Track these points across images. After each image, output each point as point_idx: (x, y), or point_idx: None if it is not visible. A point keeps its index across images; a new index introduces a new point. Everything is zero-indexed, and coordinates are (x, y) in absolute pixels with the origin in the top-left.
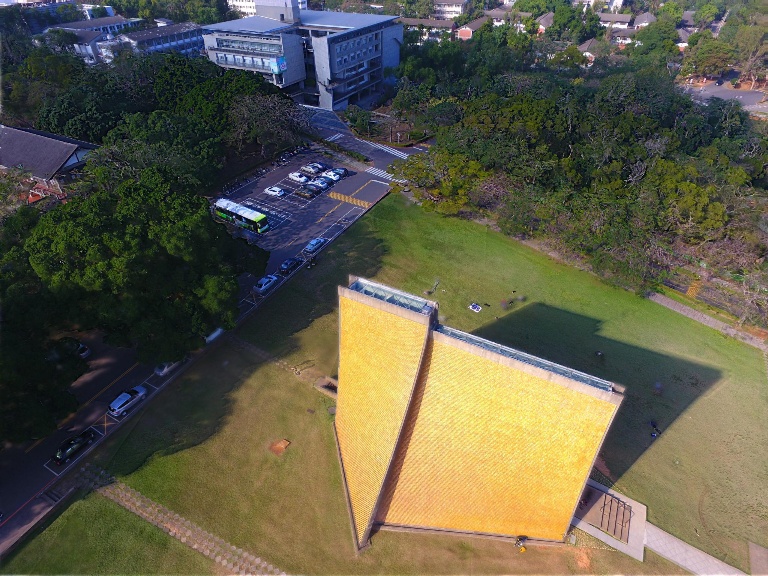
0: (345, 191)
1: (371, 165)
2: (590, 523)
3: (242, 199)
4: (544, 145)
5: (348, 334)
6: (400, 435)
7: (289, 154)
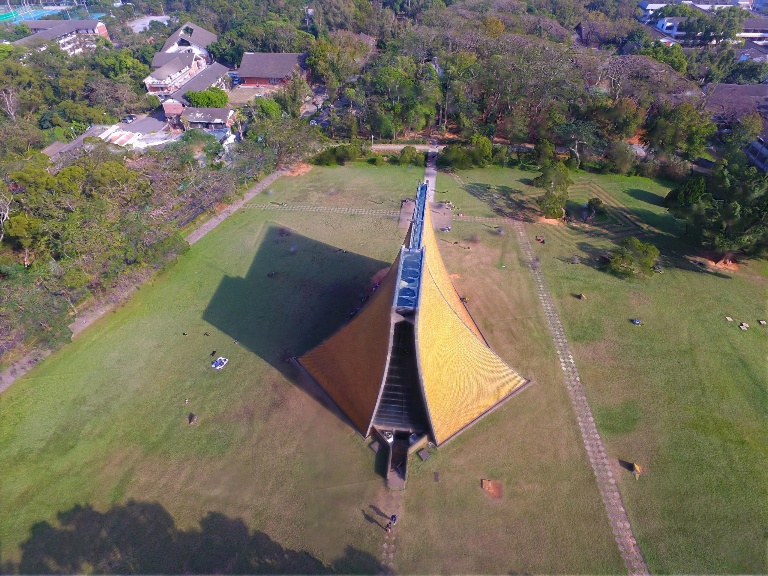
0: None
1: None
2: None
3: None
4: None
5: None
6: (469, 329)
7: None
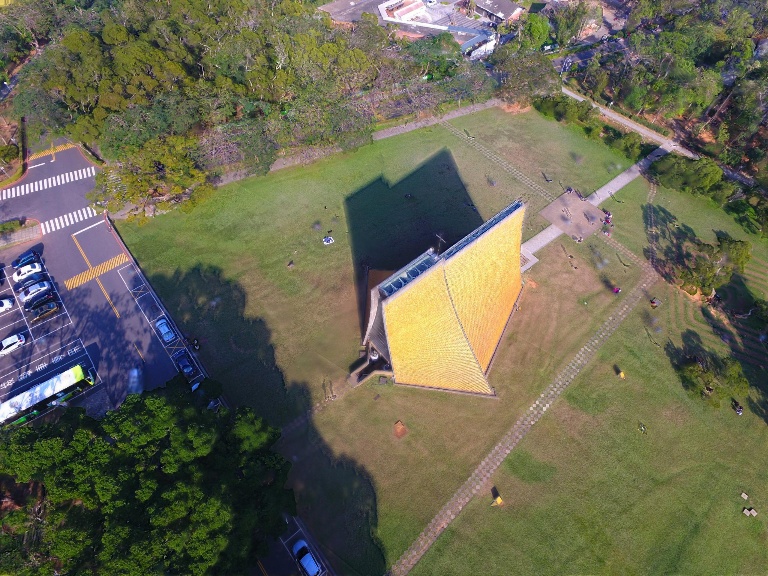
0: (74, 269)
1: (35, 223)
2: None
3: None
4: (199, 79)
5: (393, 323)
6: (463, 331)
7: None
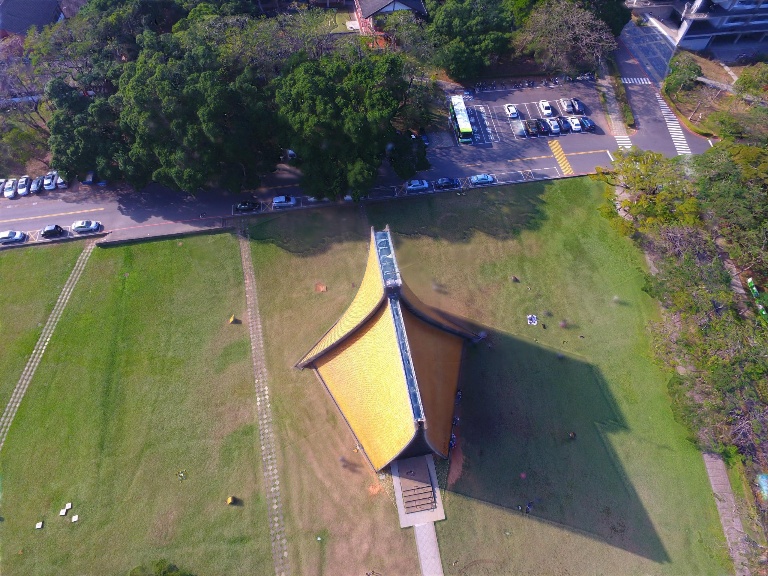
0: (568, 146)
1: (630, 134)
2: (401, 483)
3: (481, 103)
4: None
5: (369, 259)
6: (345, 336)
7: (568, 78)
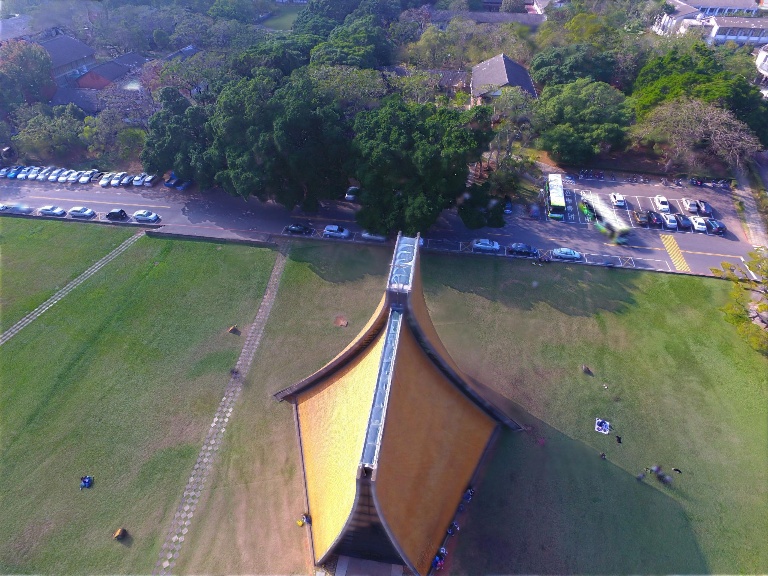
0: (687, 244)
1: None
2: None
3: (583, 188)
4: None
5: None
6: (336, 361)
7: (695, 182)
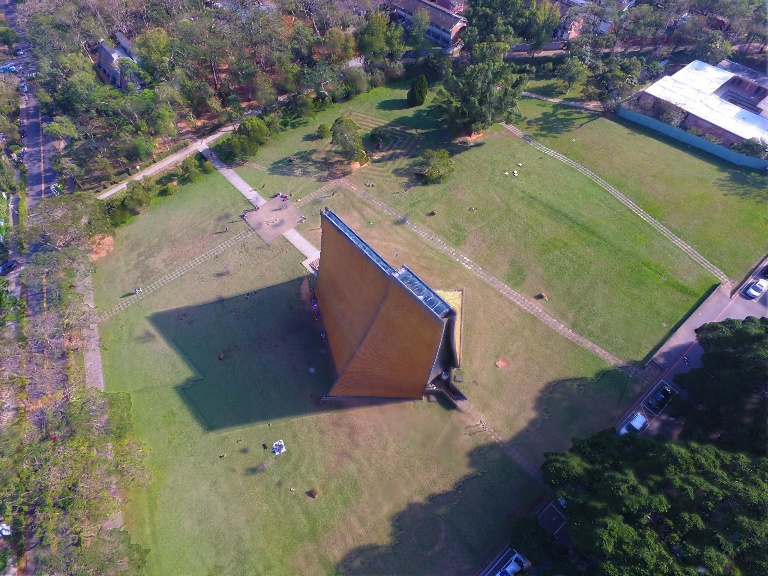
0: None
1: None
2: None
3: None
4: None
5: None
6: None
7: None
